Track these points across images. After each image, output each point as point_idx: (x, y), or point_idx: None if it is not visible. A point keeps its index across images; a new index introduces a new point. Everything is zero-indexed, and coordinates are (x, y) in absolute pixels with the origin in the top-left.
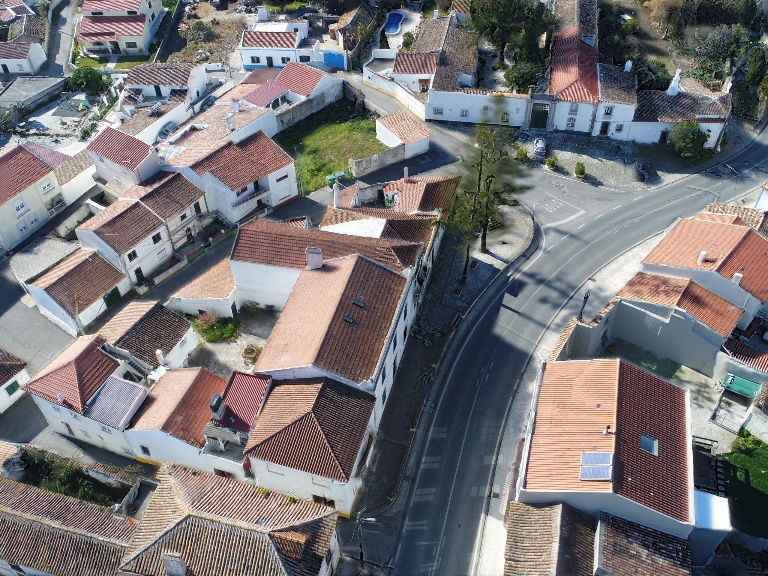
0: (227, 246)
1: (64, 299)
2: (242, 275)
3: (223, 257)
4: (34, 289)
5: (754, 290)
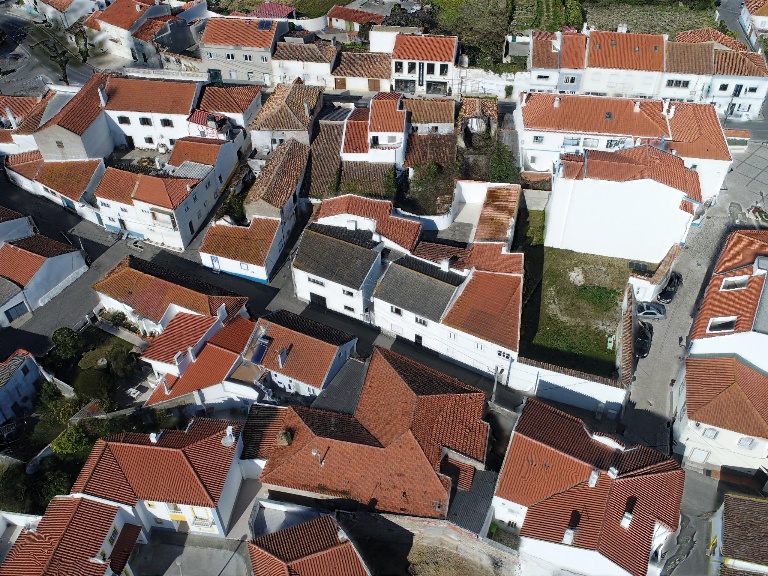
0: (8, 208)
1: (60, 253)
2: None
3: (22, 208)
4: (37, 276)
5: (162, 4)
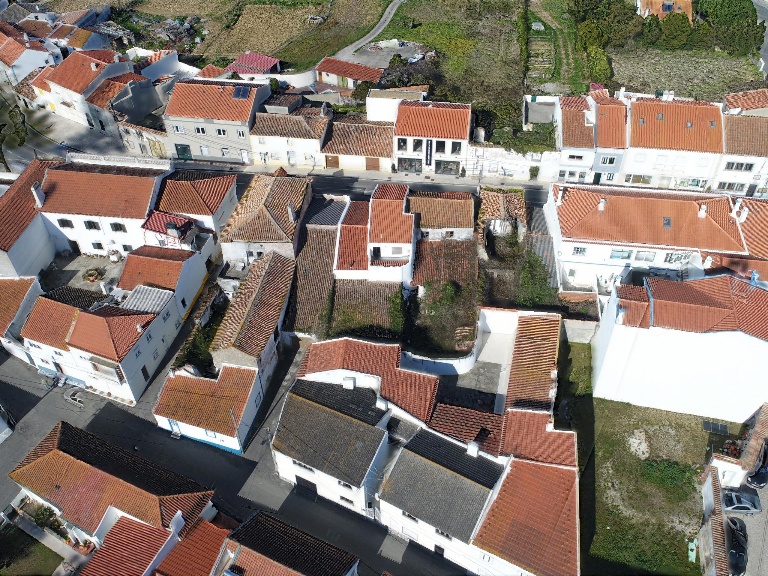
0: None
1: None
2: (18, 260)
3: None
4: None
5: None
